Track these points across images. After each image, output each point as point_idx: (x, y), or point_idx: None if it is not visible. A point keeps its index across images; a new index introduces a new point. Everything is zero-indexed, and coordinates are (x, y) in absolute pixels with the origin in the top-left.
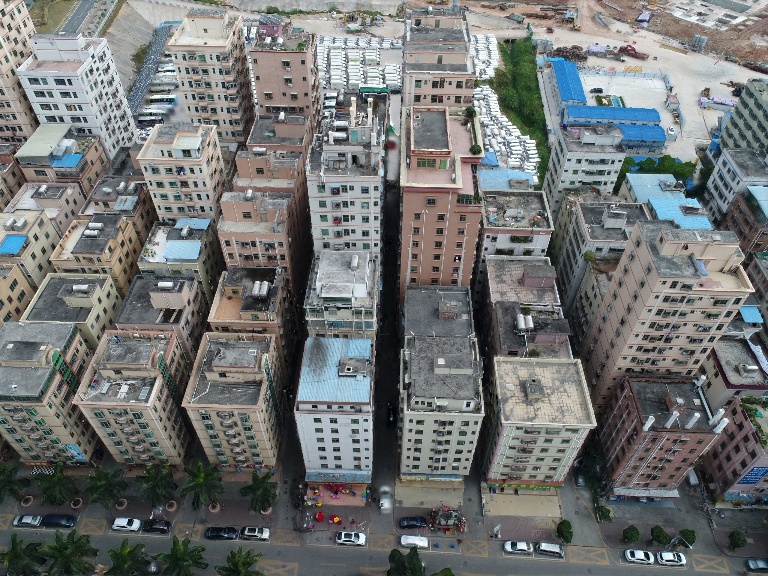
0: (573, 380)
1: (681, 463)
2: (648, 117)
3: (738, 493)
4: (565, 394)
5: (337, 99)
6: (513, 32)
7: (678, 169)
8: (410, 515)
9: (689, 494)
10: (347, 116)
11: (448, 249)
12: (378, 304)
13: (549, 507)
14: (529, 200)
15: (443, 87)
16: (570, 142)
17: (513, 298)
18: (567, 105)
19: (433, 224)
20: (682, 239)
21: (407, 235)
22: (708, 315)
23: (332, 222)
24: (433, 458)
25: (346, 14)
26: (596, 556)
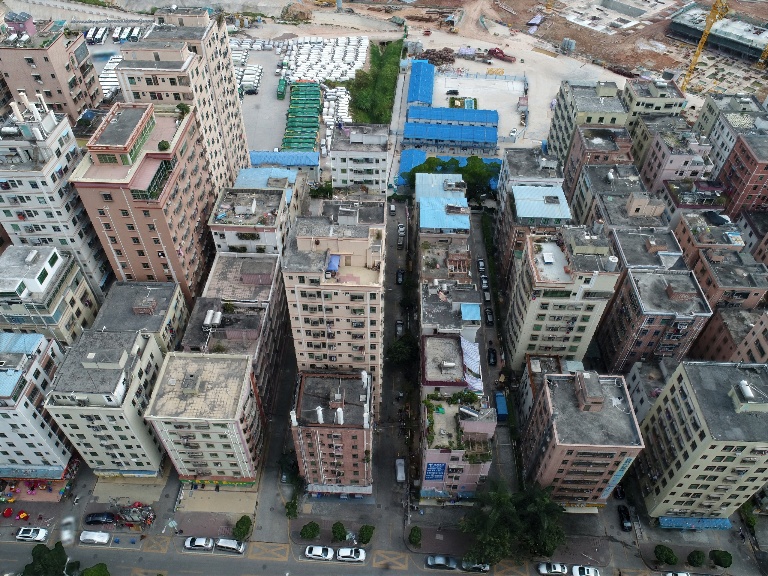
0: (239, 375)
1: (354, 459)
2: (486, 118)
3: (433, 489)
4: (224, 389)
5: (104, 97)
6: (390, 34)
7: (476, 169)
8: (100, 511)
9: (394, 491)
10: (103, 113)
11: (148, 245)
12: (86, 300)
13: (245, 503)
14: (269, 198)
15: (158, 84)
16: (340, 141)
17: (228, 295)
18: (410, 106)
19: (121, 220)
20: (313, 234)
21: (101, 231)
22: (353, 310)
23: (17, 217)
24: (109, 453)
25: (229, 15)
26: (277, 552)
